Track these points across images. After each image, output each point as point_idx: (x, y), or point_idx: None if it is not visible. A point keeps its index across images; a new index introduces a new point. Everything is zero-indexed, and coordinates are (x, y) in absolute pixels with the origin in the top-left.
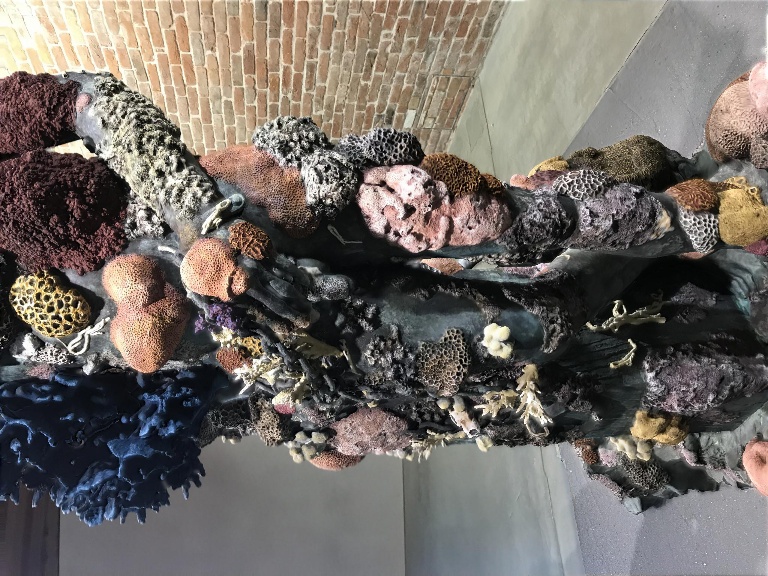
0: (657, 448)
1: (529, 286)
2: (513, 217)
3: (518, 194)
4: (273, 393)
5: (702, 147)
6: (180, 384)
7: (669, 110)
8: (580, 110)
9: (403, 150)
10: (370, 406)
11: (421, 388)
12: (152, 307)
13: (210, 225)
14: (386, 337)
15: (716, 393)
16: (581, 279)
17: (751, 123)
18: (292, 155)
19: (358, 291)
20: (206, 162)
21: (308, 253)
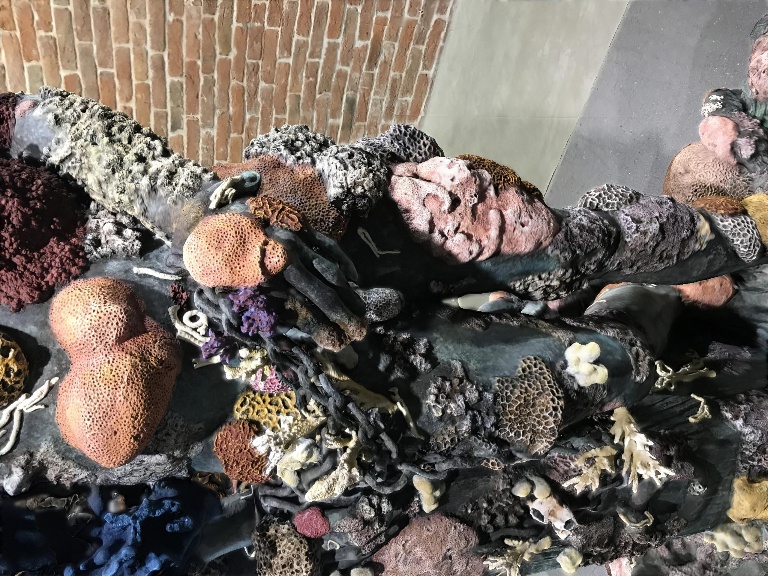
0: (733, 570)
1: (587, 316)
2: (558, 222)
3: None
4: (293, 507)
5: None
6: (159, 500)
7: None
8: None
9: (427, 148)
10: (428, 510)
11: (505, 447)
12: (129, 344)
13: (221, 196)
14: (449, 377)
15: None
16: (631, 314)
17: (716, 172)
18: (301, 152)
19: (399, 325)
20: None
21: None
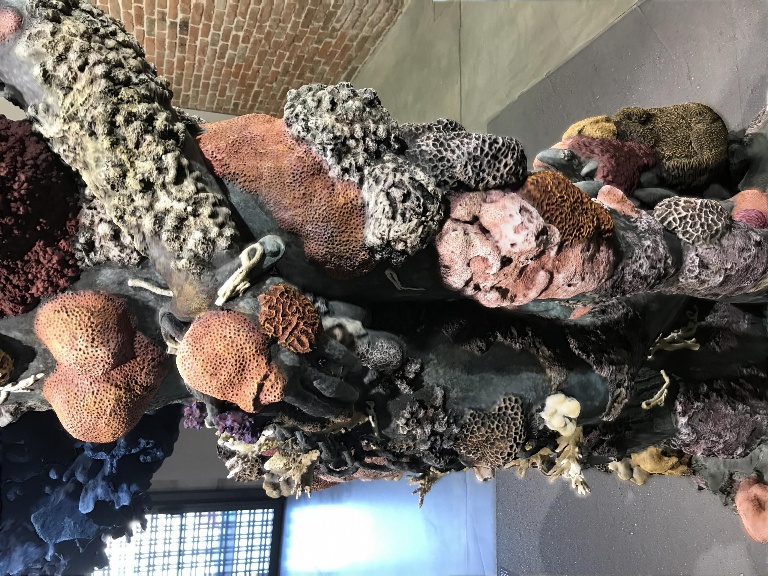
0: None
1: (596, 332)
2: (615, 265)
3: (620, 227)
4: None
5: (759, 128)
6: (137, 432)
7: (711, 58)
8: (582, 13)
9: (507, 169)
10: None
11: (454, 456)
12: (115, 373)
13: (231, 293)
14: (427, 402)
15: (745, 446)
16: (645, 317)
17: None
18: (351, 162)
19: None
20: (212, 150)
21: (346, 295)
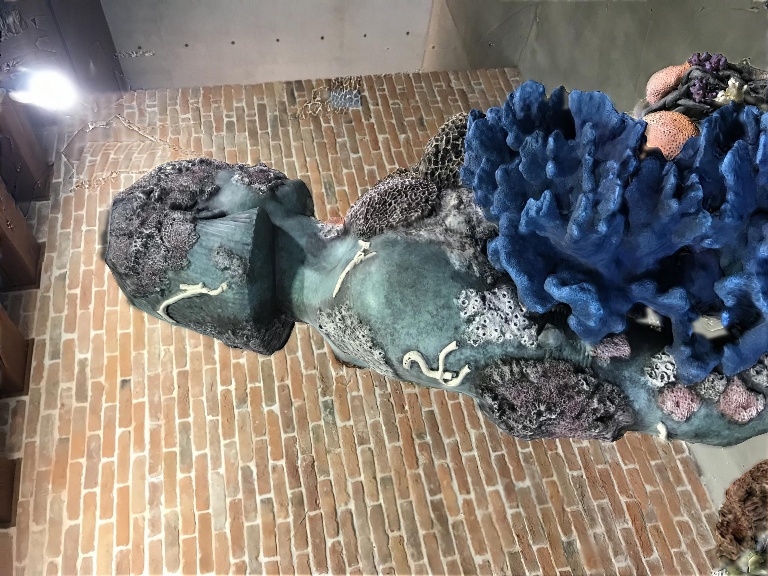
0: None
1: None
2: None
3: None
4: None
5: None
6: None
7: None
8: None
9: None
10: None
11: None
12: None
13: None
14: None
15: None
16: None
17: None
18: None
19: None
20: None
21: None
